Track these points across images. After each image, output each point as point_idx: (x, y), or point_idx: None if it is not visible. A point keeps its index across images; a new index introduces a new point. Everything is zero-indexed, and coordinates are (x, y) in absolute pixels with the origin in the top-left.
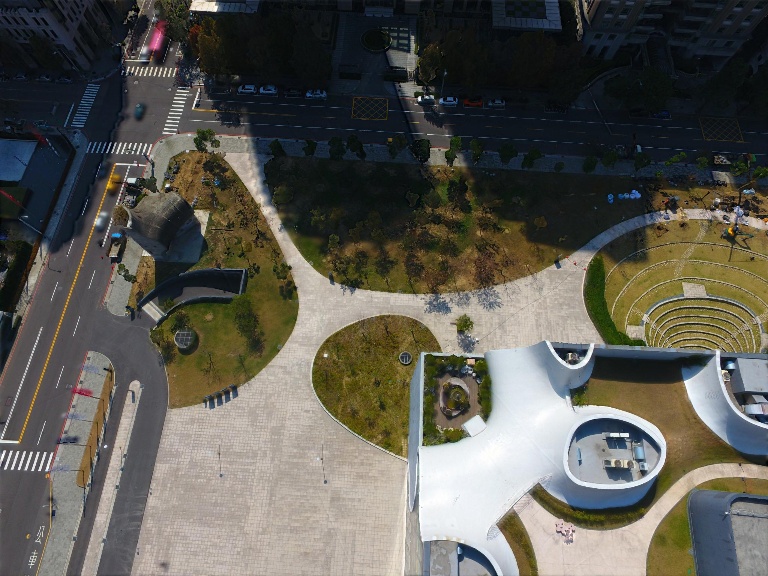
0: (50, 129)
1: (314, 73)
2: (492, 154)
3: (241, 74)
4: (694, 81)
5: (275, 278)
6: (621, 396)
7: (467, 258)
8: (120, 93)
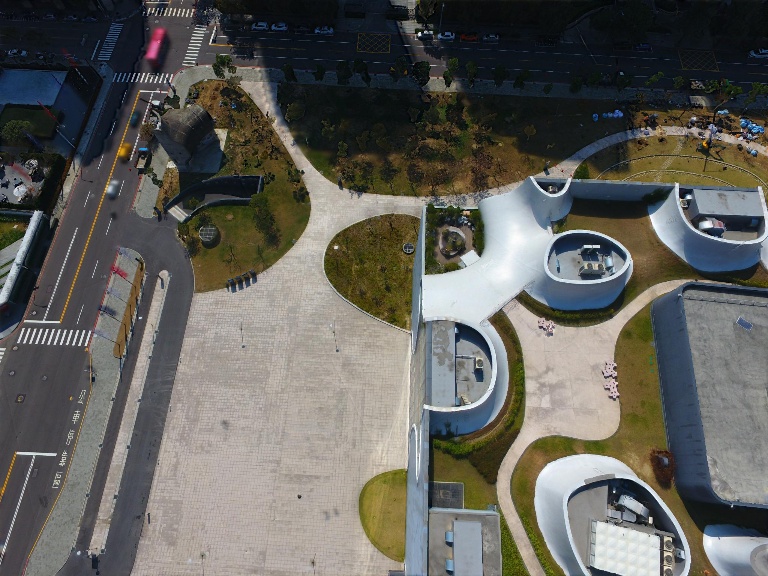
0: (78, 61)
1: (322, 6)
2: (487, 82)
3: (254, 14)
4: (674, 19)
5: (289, 185)
6: (595, 227)
7: (464, 167)
8: (142, 31)
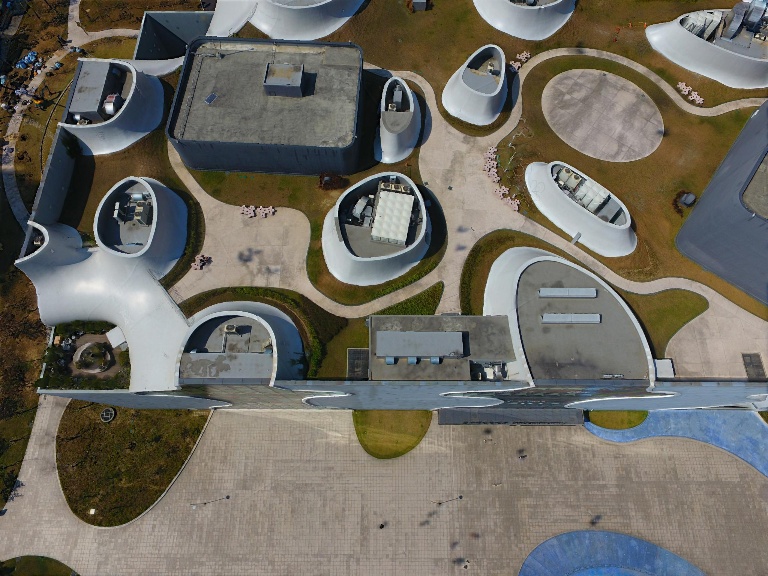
0: None
1: None
2: None
3: None
4: None
5: None
6: None
7: (7, 347)
8: None
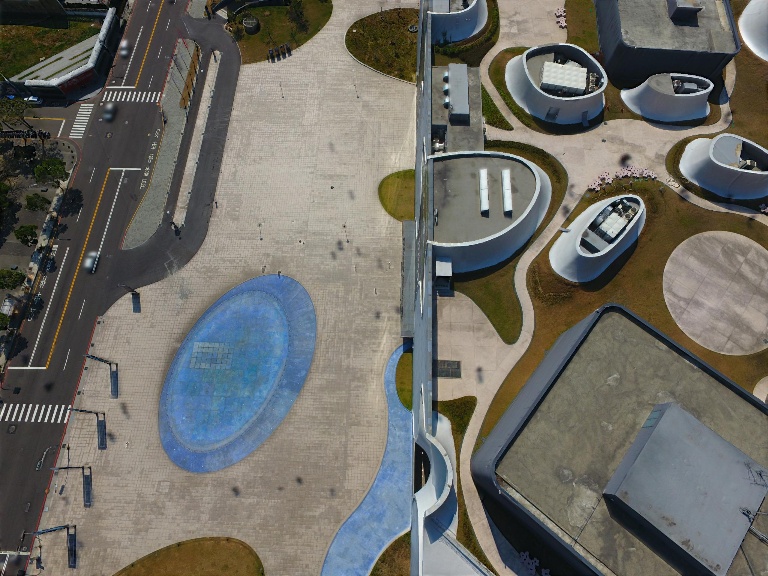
0: None
1: None
2: None
3: None
4: None
5: None
6: None
7: None
8: None
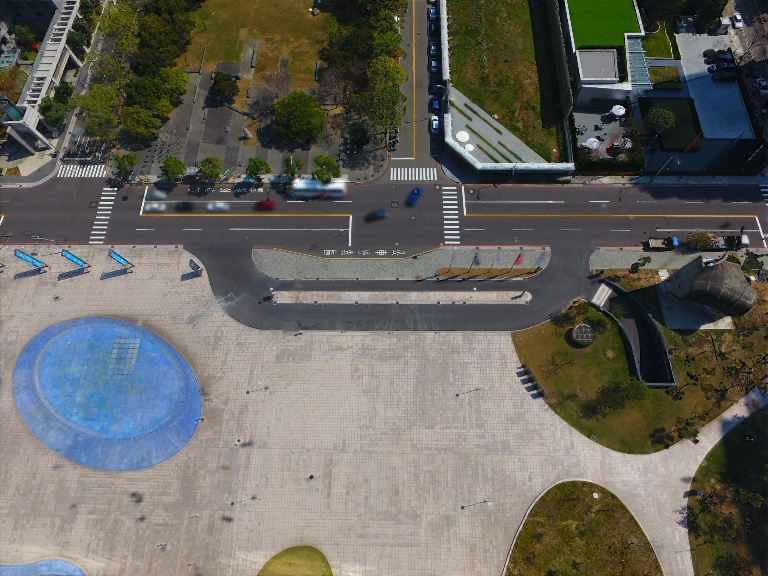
0: None
1: None
2: None
3: None
4: None
5: (673, 420)
6: None
7: None
8: None
